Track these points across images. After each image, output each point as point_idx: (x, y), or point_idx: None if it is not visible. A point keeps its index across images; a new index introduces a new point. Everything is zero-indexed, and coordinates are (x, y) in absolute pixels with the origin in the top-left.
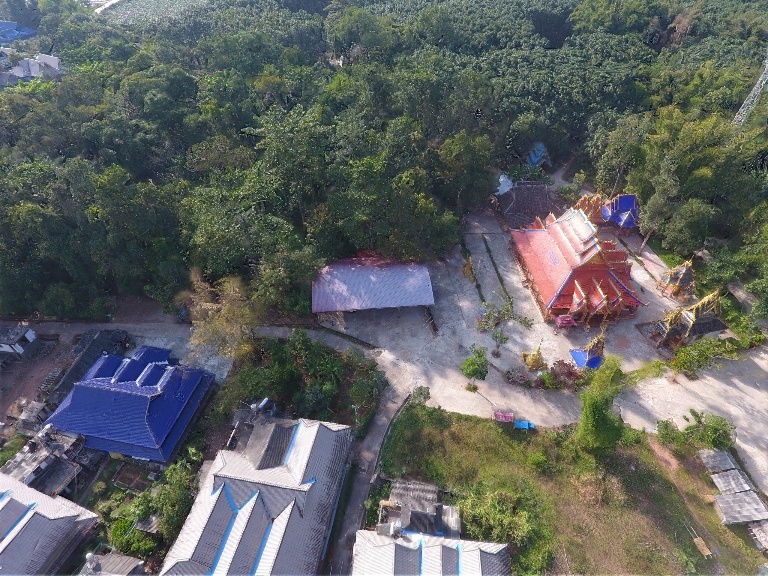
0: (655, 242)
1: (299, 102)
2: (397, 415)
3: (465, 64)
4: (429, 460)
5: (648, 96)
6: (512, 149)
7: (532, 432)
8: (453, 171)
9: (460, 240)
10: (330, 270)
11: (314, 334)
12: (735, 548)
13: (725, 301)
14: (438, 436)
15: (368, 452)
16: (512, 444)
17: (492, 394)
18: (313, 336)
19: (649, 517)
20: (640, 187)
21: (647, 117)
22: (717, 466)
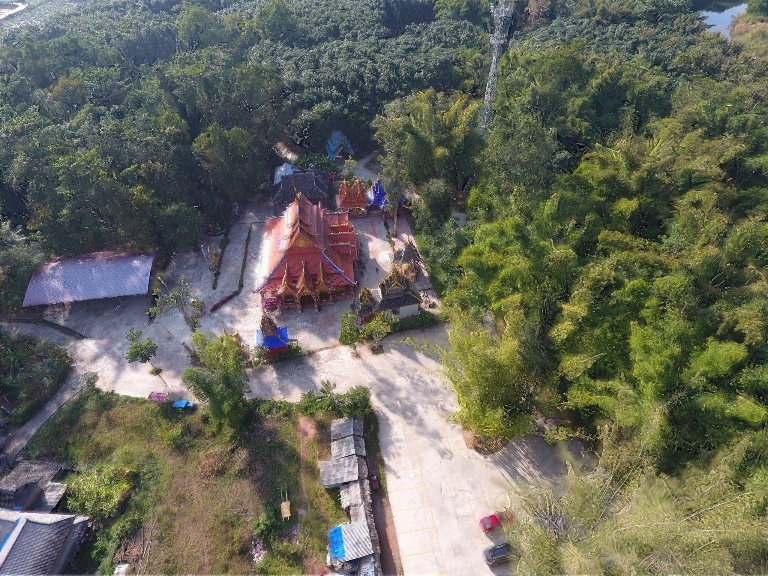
0: (416, 223)
1: (101, 103)
2: (69, 401)
3: (290, 57)
4: (69, 441)
5: (463, 80)
6: (311, 139)
7: (187, 410)
8: (212, 163)
9: (225, 230)
10: (57, 265)
11: (31, 328)
12: (322, 510)
13: (443, 277)
14: (93, 418)
15: (21, 437)
16: (161, 423)
17: (172, 376)
18: (29, 330)
19: (256, 485)
20: (407, 170)
21: (409, 101)
22: (339, 434)
